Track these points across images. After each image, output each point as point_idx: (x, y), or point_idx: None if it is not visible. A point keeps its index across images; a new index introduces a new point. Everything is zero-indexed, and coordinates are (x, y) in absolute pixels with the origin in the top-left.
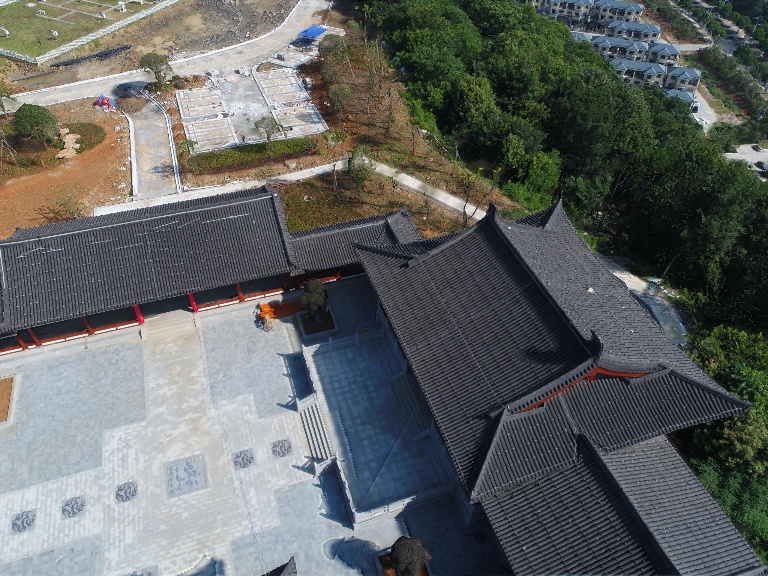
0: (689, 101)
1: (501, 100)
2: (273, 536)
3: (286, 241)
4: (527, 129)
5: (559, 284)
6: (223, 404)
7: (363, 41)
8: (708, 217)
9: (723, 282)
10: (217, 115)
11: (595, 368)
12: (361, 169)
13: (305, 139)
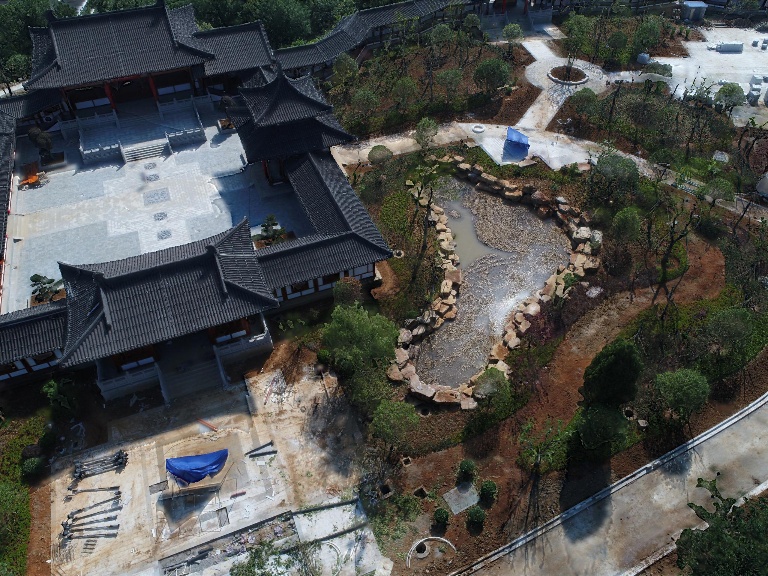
0: None
1: None
2: (203, 163)
3: None
4: None
5: None
6: (107, 191)
7: None
8: None
9: None
10: None
11: None
12: None
13: None
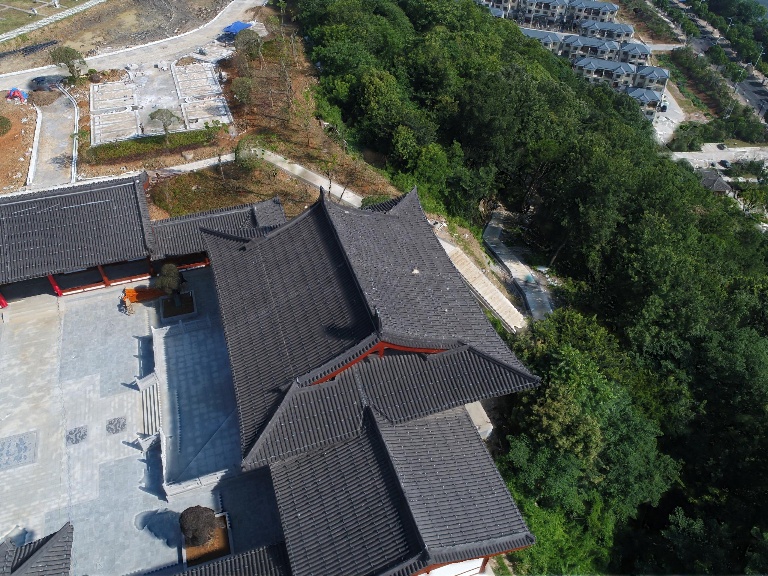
0: (655, 100)
1: (419, 94)
2: (88, 508)
3: (146, 226)
4: (417, 121)
5: (380, 265)
6: (69, 384)
7: (281, 36)
8: (586, 206)
9: (604, 271)
10: (126, 108)
11: (379, 342)
12: (246, 159)
13: (206, 131)
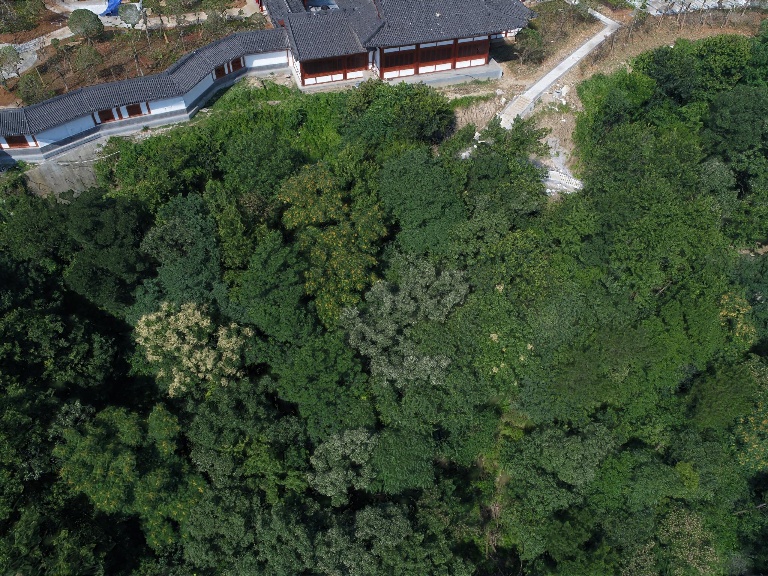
0: None
1: None
2: None
3: None
4: (662, 55)
5: None
6: None
7: None
8: None
9: None
10: None
11: None
12: (578, 5)
13: None
